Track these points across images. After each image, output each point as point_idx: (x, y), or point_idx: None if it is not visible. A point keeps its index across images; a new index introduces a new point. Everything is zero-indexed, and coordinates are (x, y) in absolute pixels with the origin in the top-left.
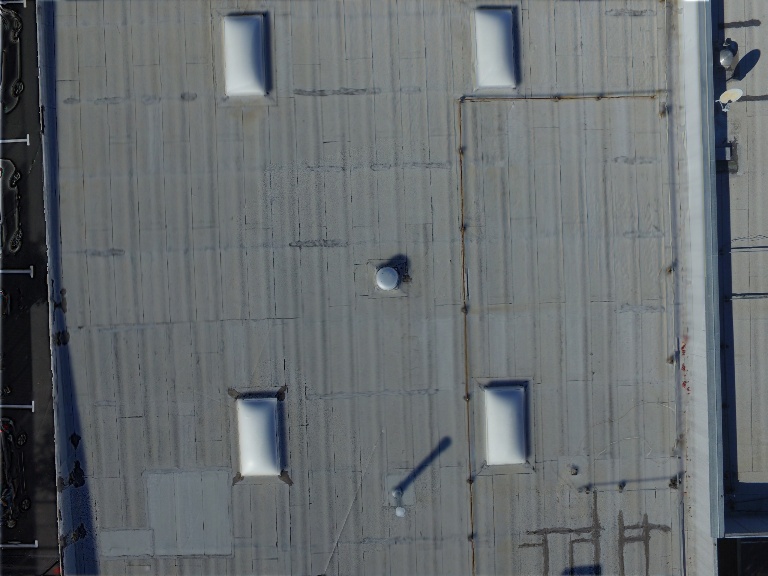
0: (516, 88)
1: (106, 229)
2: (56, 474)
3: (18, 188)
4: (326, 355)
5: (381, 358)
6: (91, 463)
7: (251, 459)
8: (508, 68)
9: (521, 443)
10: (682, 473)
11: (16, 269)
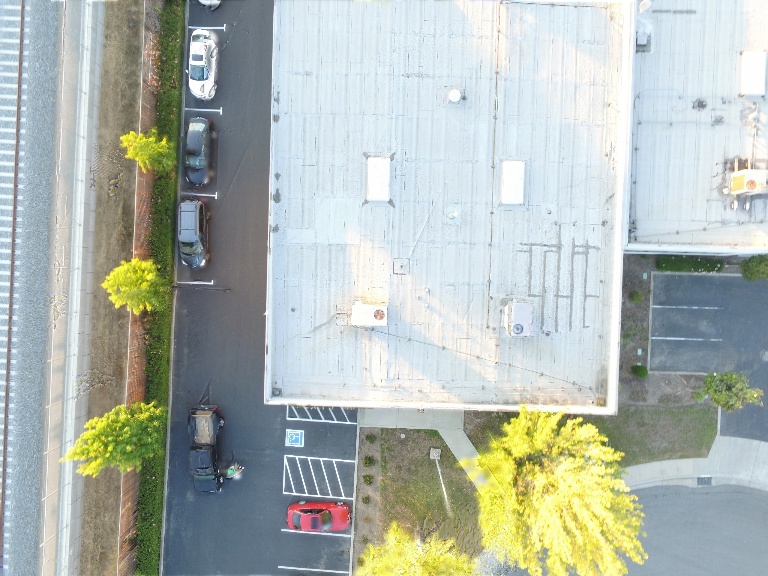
0: None
1: (304, 60)
2: (269, 191)
3: (217, 57)
4: (418, 137)
5: (448, 141)
6: (285, 190)
7: (375, 189)
8: None
9: (521, 192)
10: (609, 218)
11: (211, 109)
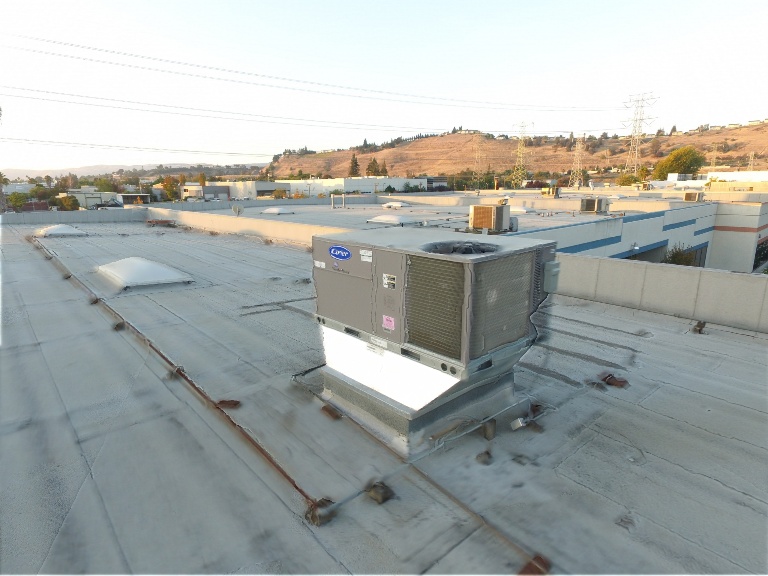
0: None
1: None
2: None
3: None
4: None
5: None
6: None
7: None
8: None
9: None
10: None
11: None
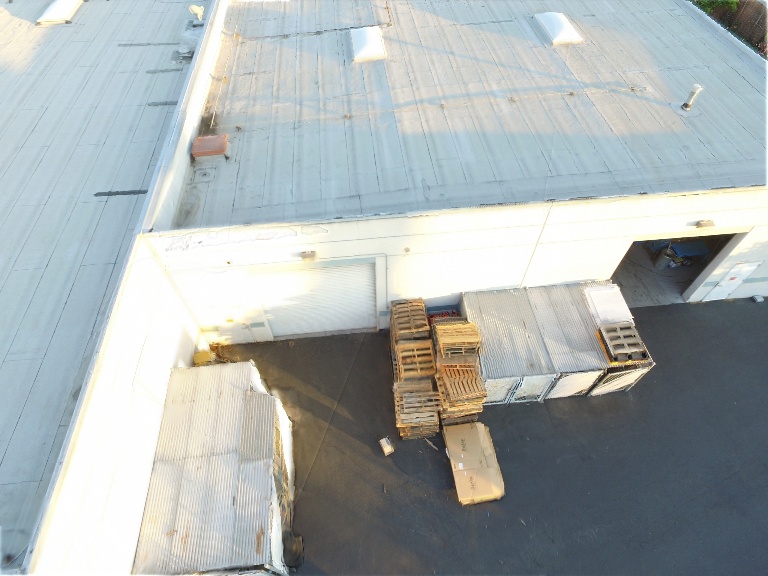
0: None
1: None
2: None
3: None
4: None
5: None
6: None
7: None
8: None
9: None
10: None
11: None
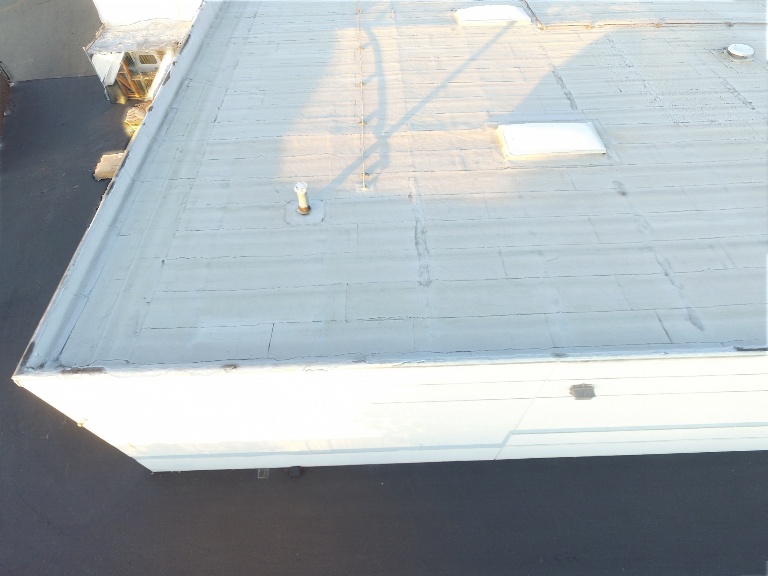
0: None
1: None
2: None
3: None
4: None
5: None
6: None
7: None
8: None
9: None
10: None
11: None
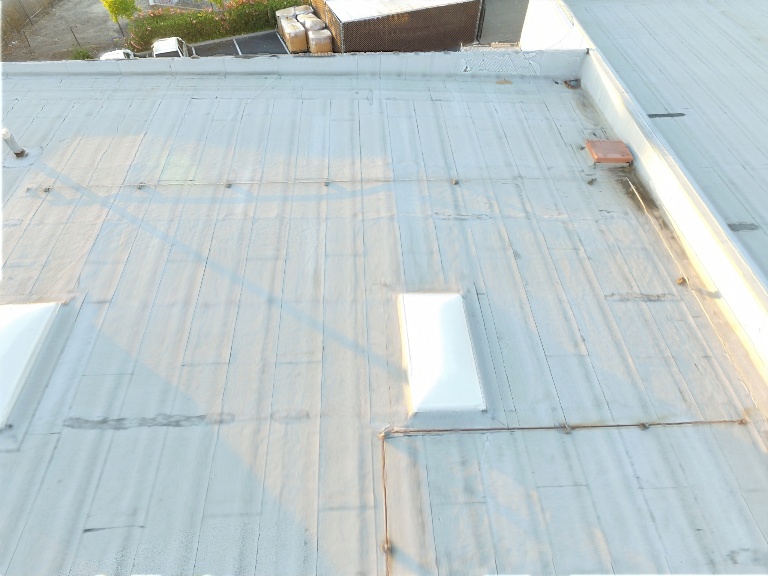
0: (487, 410)
1: None
2: None
3: None
4: None
5: None
6: None
7: None
8: (467, 376)
9: None
10: None
11: None
